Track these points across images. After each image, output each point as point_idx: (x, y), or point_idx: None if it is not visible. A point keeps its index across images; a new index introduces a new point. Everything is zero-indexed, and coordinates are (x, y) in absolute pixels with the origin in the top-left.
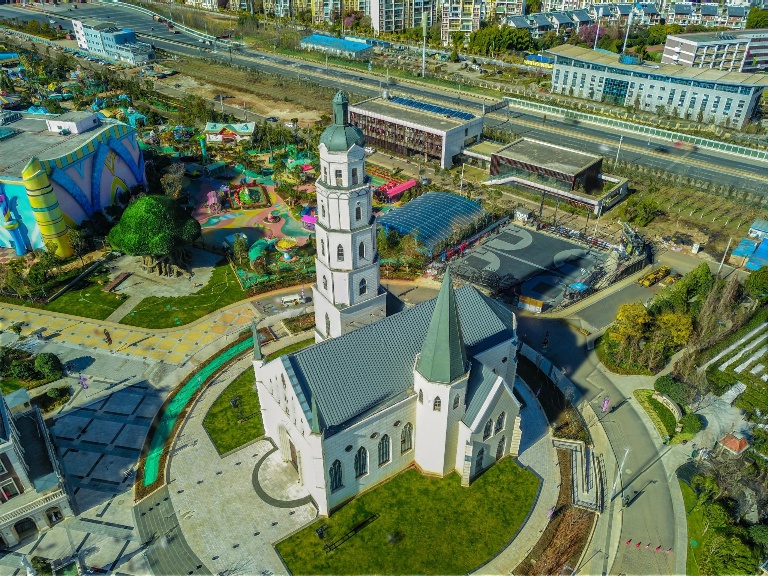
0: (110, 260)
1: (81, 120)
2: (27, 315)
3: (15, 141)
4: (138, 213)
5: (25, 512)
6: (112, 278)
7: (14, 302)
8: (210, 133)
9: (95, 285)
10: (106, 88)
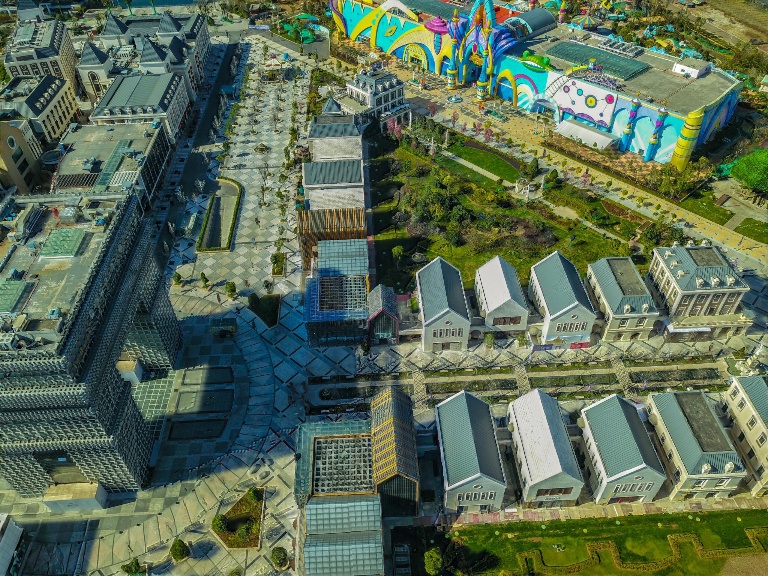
0: (711, 182)
1: (702, 68)
2: (669, 207)
3: (652, 76)
4: (767, 161)
5: (734, 324)
6: (717, 196)
7: (658, 195)
8: (767, 85)
9: (707, 198)
10: (650, 13)
